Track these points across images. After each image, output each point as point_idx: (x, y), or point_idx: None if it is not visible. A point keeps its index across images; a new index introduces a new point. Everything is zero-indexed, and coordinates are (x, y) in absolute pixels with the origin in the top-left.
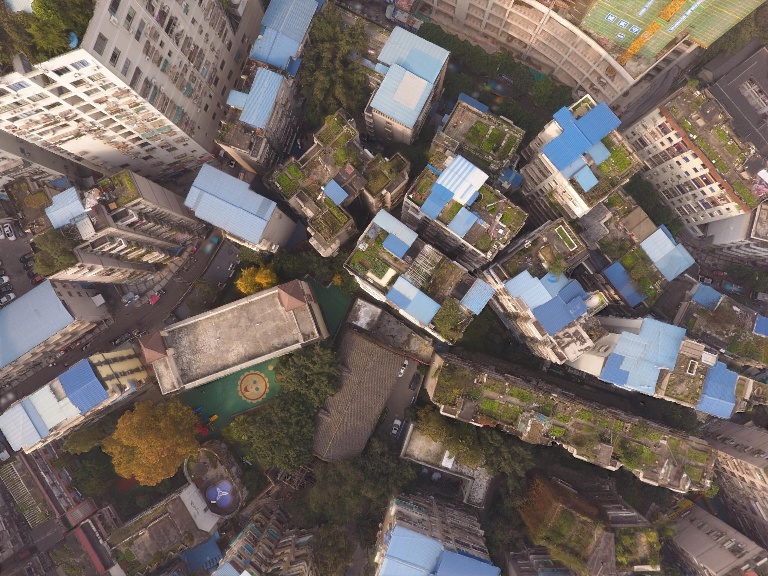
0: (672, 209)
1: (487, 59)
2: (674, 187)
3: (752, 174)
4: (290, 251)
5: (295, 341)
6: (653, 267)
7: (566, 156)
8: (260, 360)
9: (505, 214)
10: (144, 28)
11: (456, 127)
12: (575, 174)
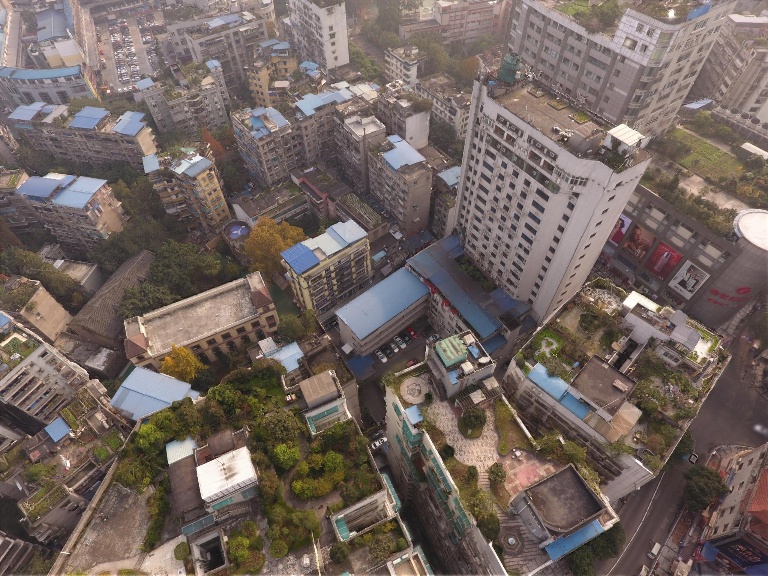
0: None
1: None
2: None
3: None
4: None
5: (152, 321)
6: None
7: None
8: (180, 302)
9: None
10: None
11: None
12: None
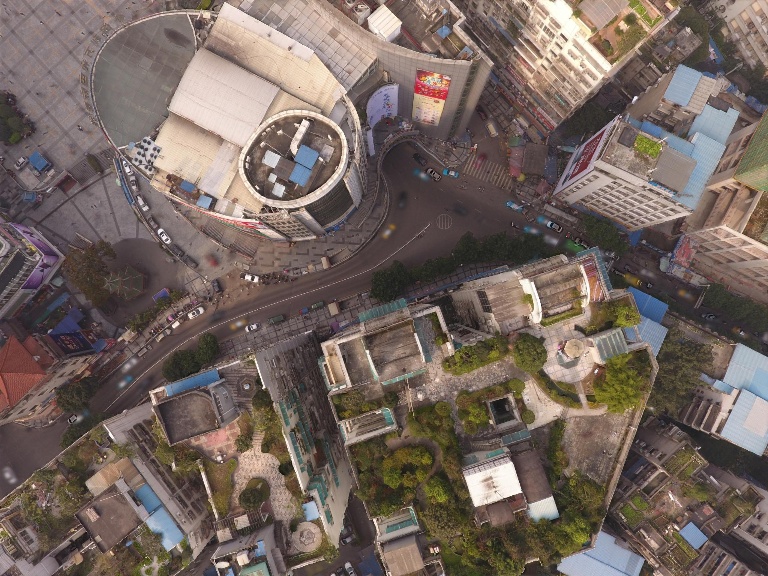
0: None
1: None
2: None
3: None
4: None
5: None
6: None
7: None
8: None
9: None
10: None
11: None
12: None
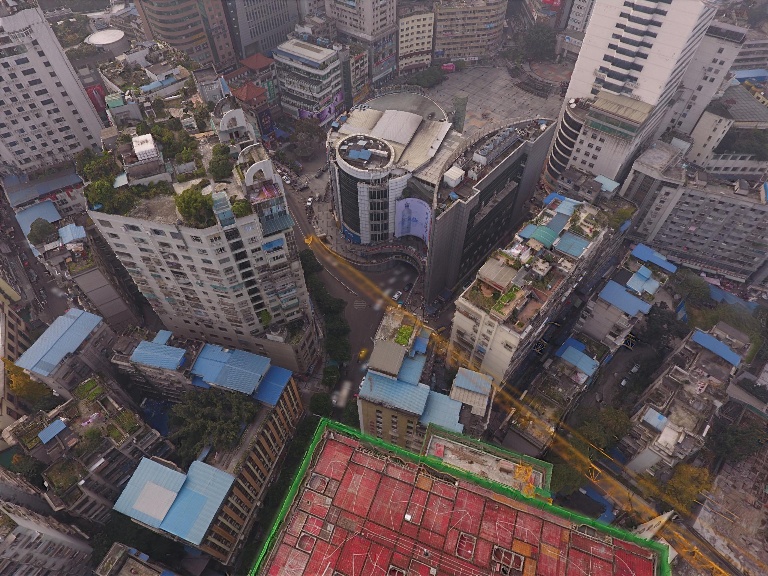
0: None
1: None
2: None
3: None
4: None
5: None
6: None
7: None
8: None
9: None
10: (152, 253)
11: (132, 573)
12: None
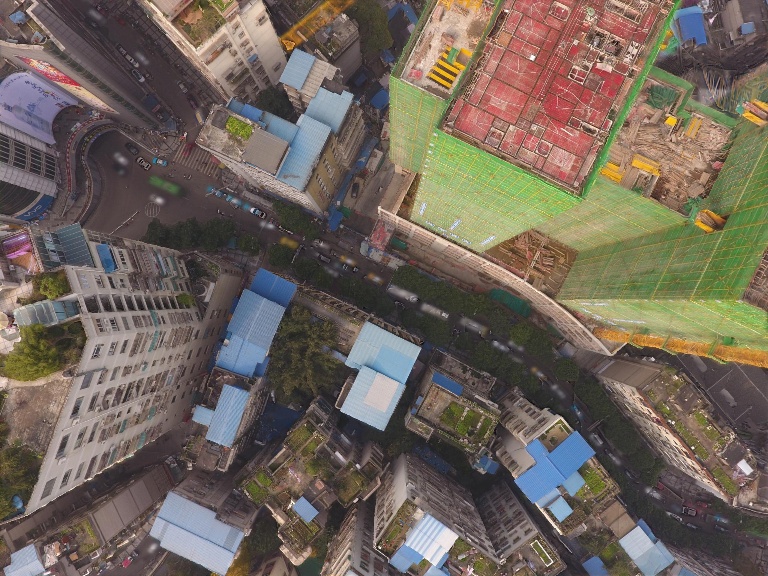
0: (654, 446)
1: (464, 302)
2: (655, 436)
3: (732, 464)
4: (264, 520)
5: None
6: (632, 564)
7: (539, 489)
8: None
9: (477, 563)
10: (98, 425)
11: (430, 408)
12: (549, 506)
